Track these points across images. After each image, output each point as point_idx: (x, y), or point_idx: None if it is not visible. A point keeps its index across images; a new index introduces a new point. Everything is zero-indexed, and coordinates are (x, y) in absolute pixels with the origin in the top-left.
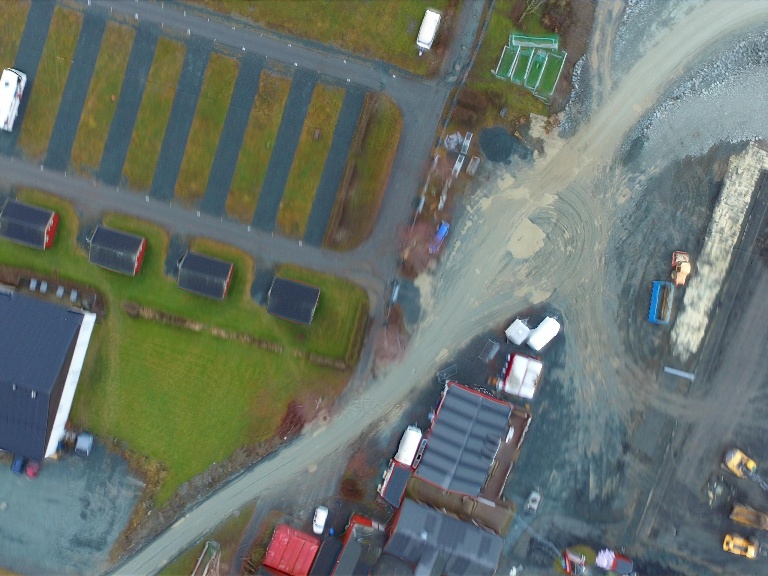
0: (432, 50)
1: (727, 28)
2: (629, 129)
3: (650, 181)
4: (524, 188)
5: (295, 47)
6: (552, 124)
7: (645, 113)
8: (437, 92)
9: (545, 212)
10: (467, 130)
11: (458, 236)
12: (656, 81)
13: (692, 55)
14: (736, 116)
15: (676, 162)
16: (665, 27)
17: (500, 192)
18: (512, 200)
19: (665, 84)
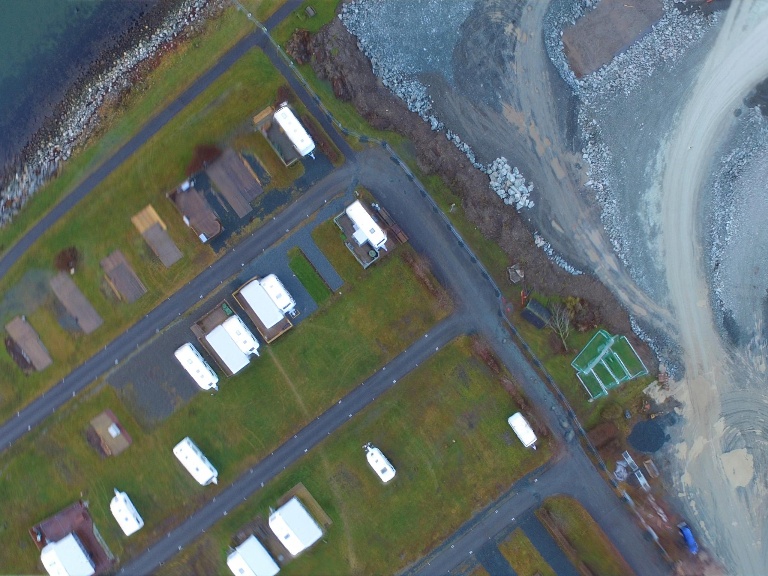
0: (540, 438)
1: (695, 188)
2: (713, 322)
3: (765, 334)
4: (697, 440)
5: (457, 544)
6: (664, 381)
7: (710, 300)
8: (573, 455)
9: (728, 437)
10: (620, 454)
11: (696, 520)
12: (692, 274)
13: (694, 230)
14: (765, 227)
15: (766, 303)
16: (657, 236)
17: (686, 461)
18: (699, 456)
19: (700, 268)
